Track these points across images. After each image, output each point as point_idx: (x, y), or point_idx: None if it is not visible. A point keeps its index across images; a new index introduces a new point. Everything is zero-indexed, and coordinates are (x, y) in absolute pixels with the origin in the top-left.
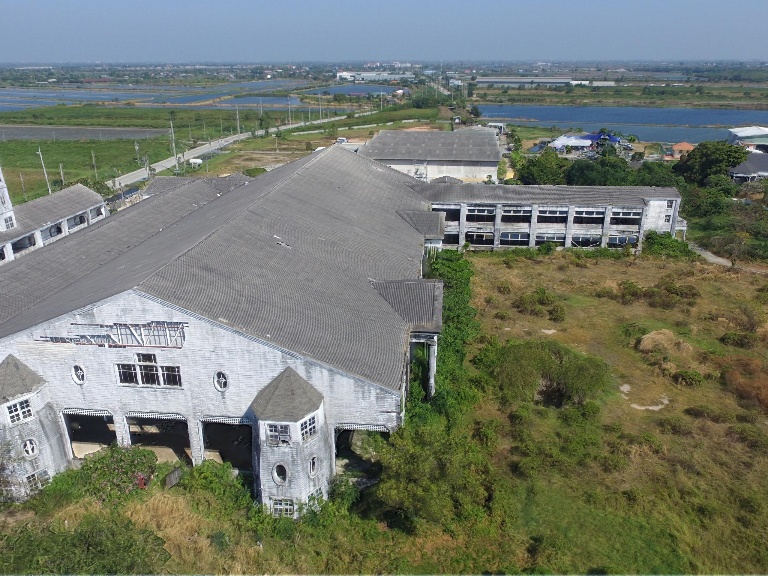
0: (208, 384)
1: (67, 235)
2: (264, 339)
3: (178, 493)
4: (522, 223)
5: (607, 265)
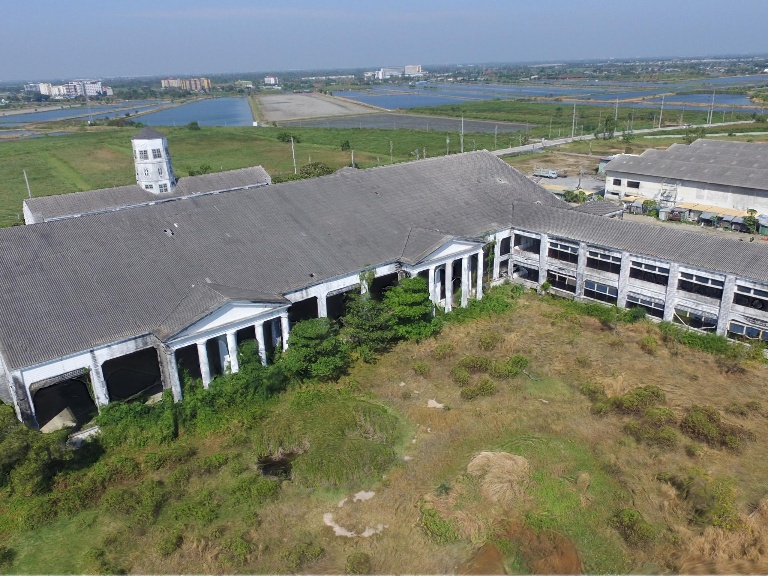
0: None
1: None
2: None
3: None
4: (611, 273)
5: (691, 360)
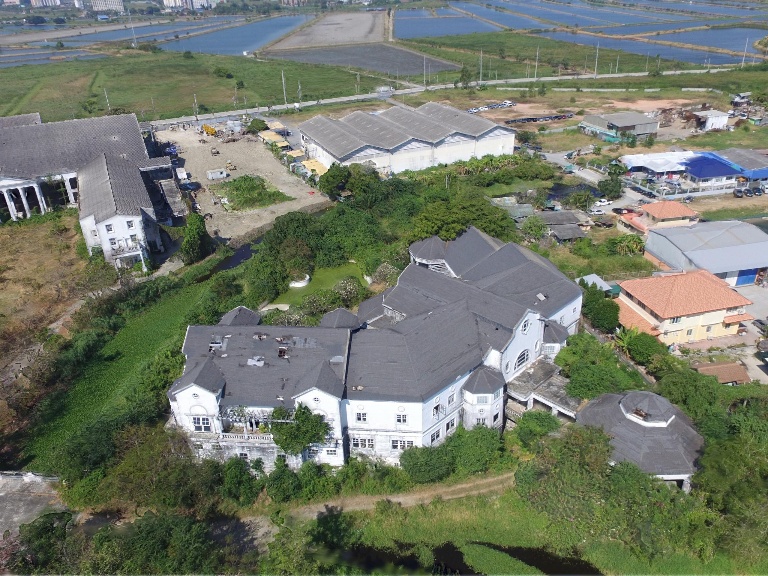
0: None
1: None
2: None
3: None
4: None
5: (61, 257)
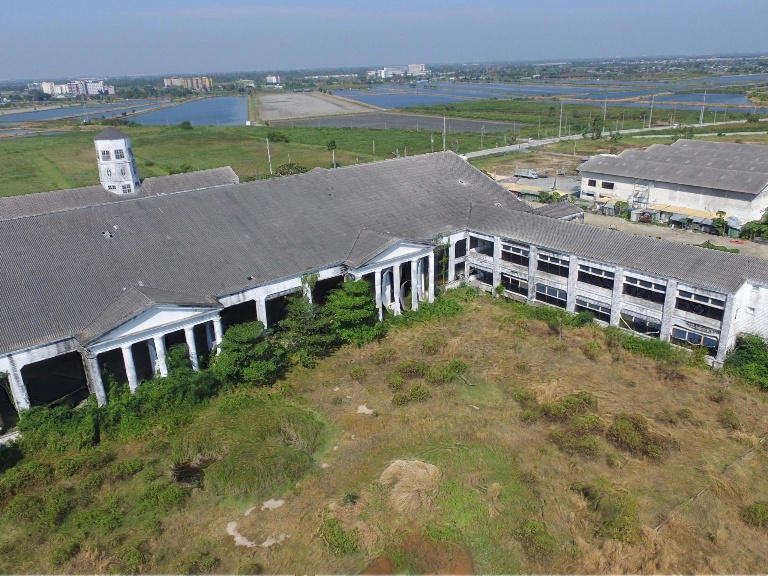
0: None
1: None
2: None
3: None
4: (560, 276)
5: (631, 366)
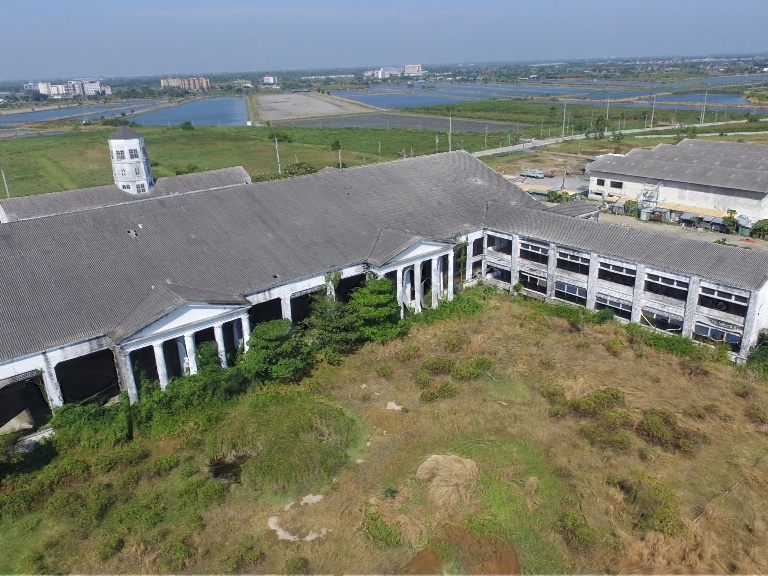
0: None
1: None
2: None
3: None
4: (580, 274)
5: (655, 362)
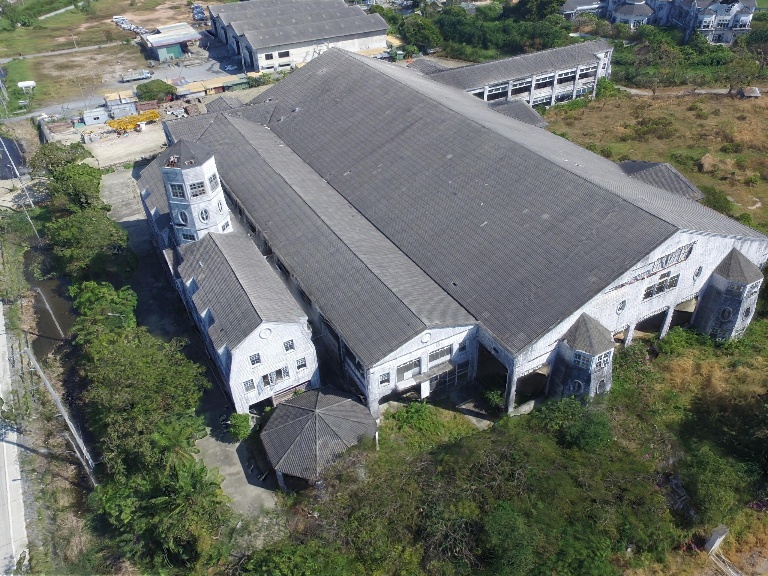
0: (690, 278)
1: (249, 215)
2: (730, 234)
3: (661, 359)
4: (524, 93)
5: (589, 114)
